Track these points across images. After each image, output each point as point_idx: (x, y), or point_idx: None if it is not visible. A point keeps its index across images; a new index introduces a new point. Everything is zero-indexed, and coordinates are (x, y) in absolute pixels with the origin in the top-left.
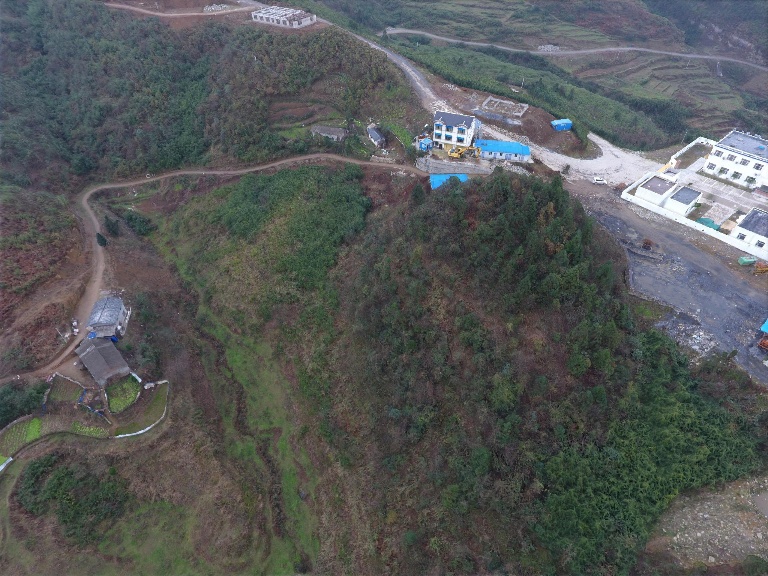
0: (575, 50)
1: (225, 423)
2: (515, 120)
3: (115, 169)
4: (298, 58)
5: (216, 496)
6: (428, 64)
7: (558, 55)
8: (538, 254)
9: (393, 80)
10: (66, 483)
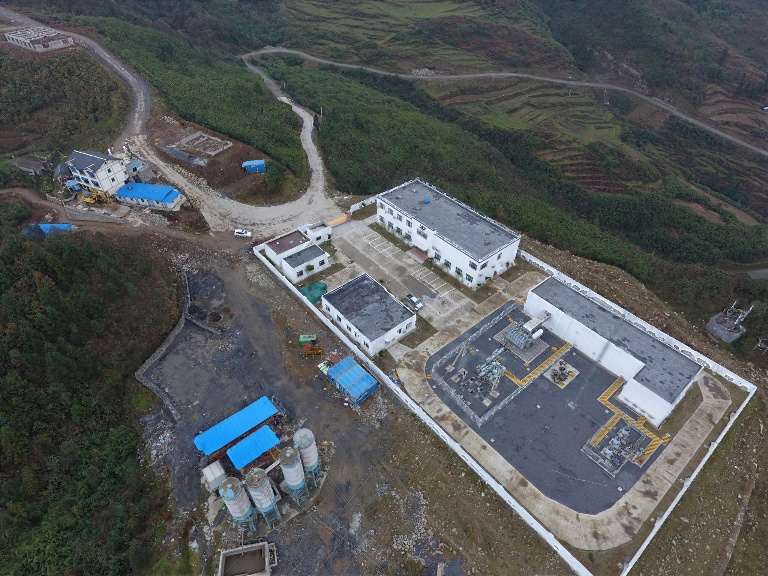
0: (451, 75)
1: None
2: (203, 160)
3: None
4: (20, 84)
5: None
6: (167, 93)
7: (428, 80)
8: None
9: (110, 111)
10: None
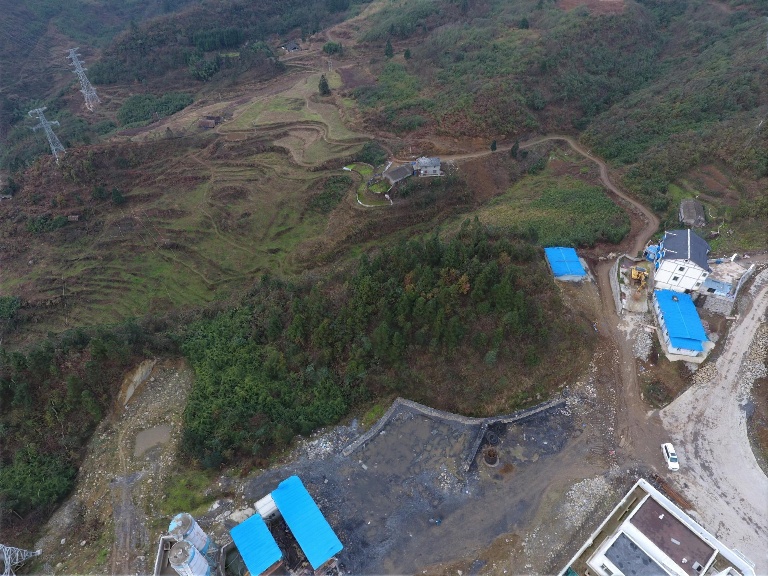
0: None
1: (373, 241)
2: None
3: (583, 134)
4: None
5: (325, 242)
6: None
7: None
8: (397, 269)
9: None
10: (337, 189)
